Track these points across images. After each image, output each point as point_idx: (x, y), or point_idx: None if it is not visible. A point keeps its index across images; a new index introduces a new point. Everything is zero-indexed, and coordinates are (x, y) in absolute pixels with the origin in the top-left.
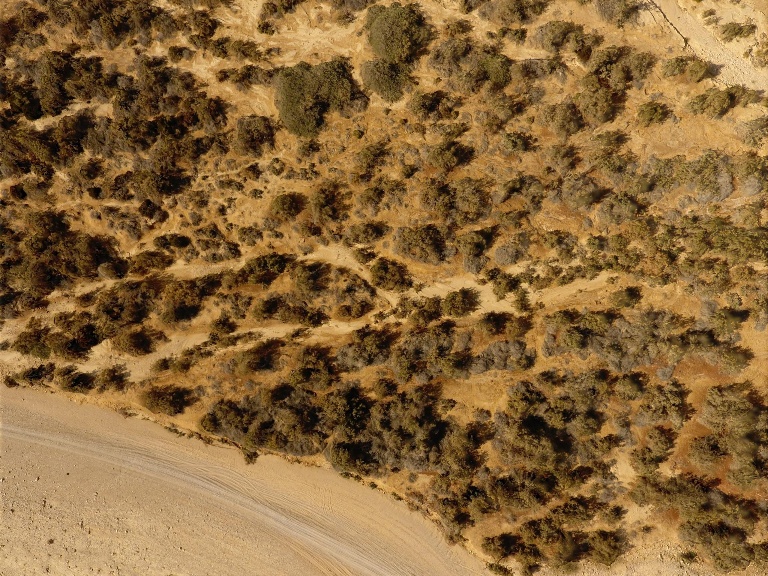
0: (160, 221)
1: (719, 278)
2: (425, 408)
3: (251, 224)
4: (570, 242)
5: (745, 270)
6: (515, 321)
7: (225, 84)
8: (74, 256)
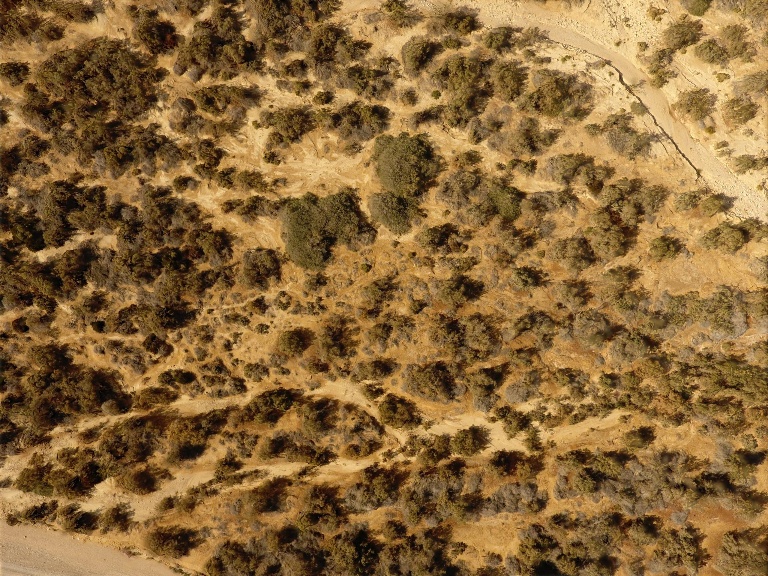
0: (165, 355)
1: (734, 419)
2: (435, 553)
3: (257, 360)
4: (582, 380)
5: (760, 411)
6: (526, 461)
7: (231, 215)
8: (77, 394)
